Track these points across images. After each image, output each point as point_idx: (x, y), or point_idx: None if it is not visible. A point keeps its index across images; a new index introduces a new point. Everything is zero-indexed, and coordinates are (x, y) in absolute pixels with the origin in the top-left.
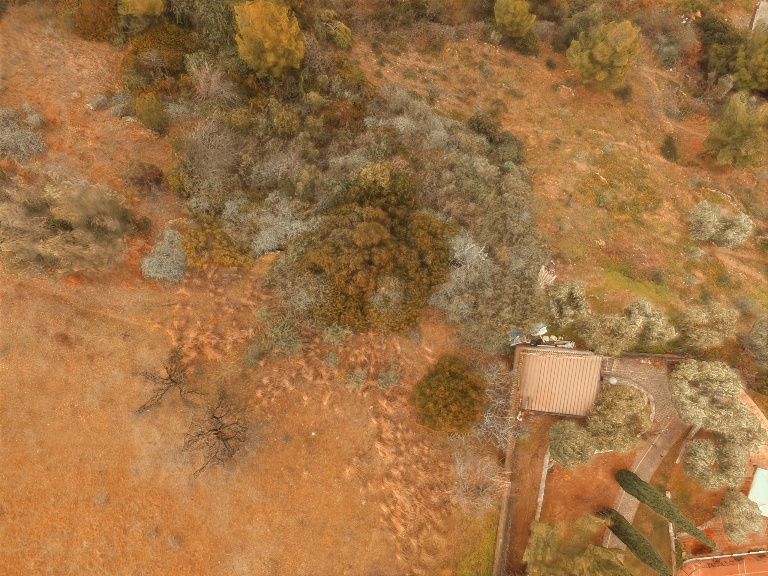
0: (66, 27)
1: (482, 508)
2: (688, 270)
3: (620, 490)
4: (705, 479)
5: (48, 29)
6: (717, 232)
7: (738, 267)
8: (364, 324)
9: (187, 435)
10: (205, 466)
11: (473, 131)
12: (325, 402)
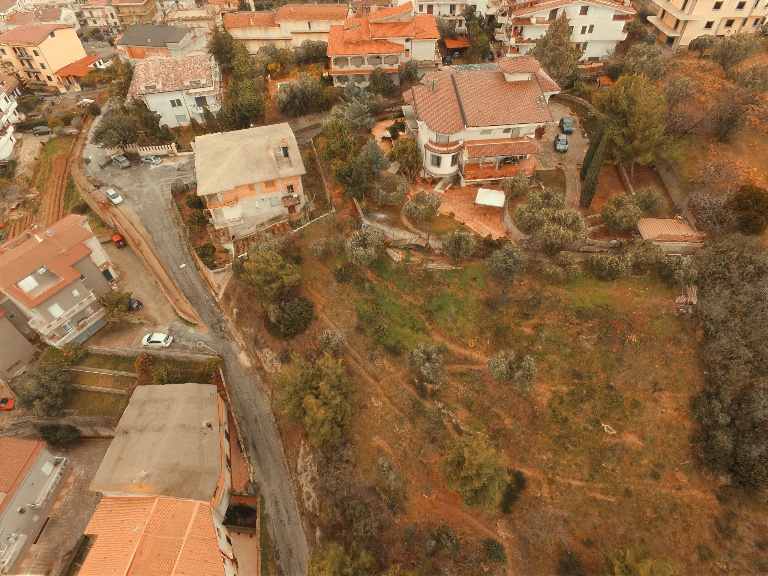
0: None
1: None
2: (537, 333)
3: None
4: None
5: None
6: (516, 362)
7: (471, 353)
8: None
9: None
10: None
11: (767, 465)
12: None
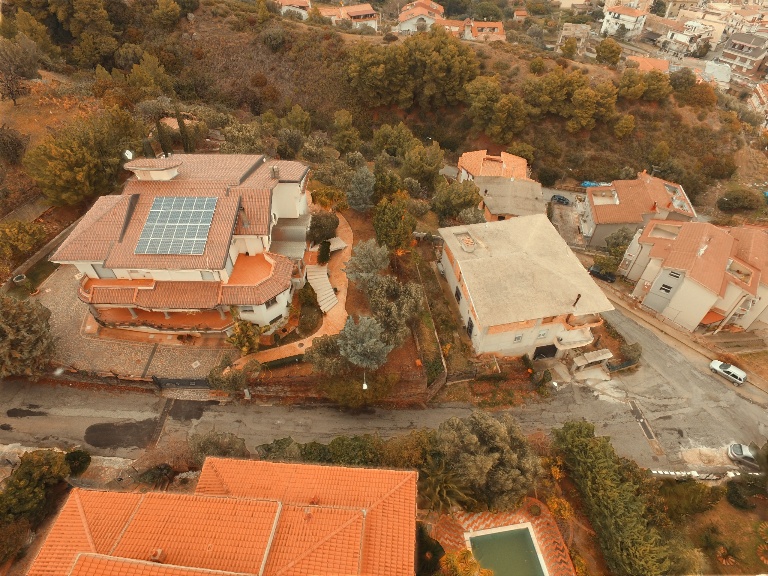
0: (71, 79)
1: (98, 117)
2: None
3: None
4: None
5: (64, 77)
6: None
7: None
8: (101, 95)
9: (0, 82)
10: None
11: None
12: (64, 104)
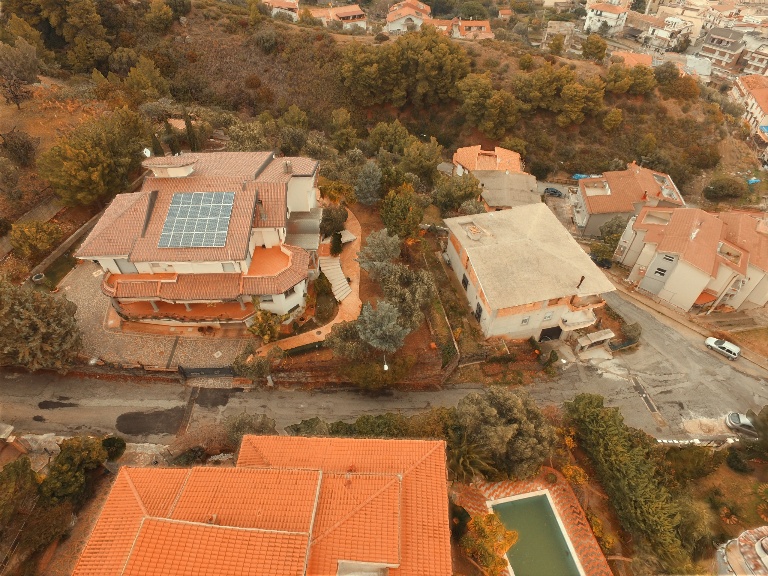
0: (67, 84)
1: None
2: None
3: None
4: None
5: (60, 81)
6: None
7: None
8: (104, 98)
9: None
10: (2, 94)
11: None
12: (68, 107)
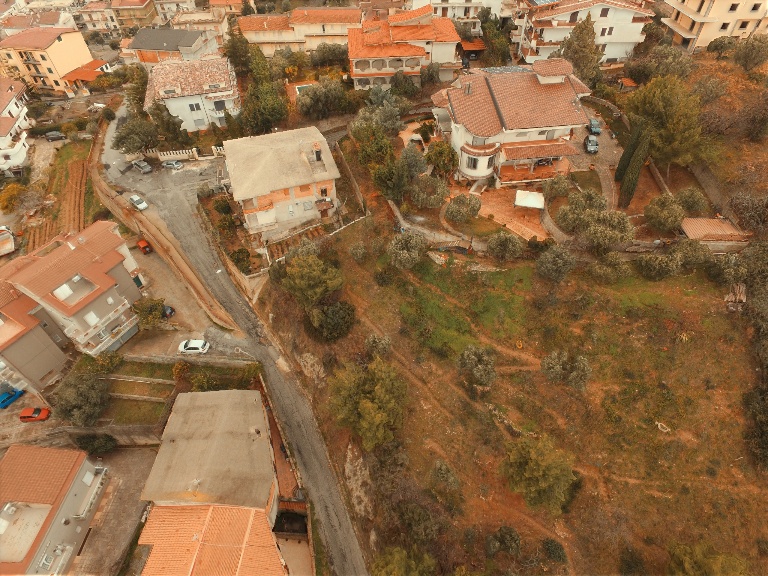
0: None
1: None
2: (587, 333)
3: (617, 202)
4: (595, 193)
5: None
6: (569, 362)
7: (519, 354)
8: None
9: None
10: None
11: None
12: None
